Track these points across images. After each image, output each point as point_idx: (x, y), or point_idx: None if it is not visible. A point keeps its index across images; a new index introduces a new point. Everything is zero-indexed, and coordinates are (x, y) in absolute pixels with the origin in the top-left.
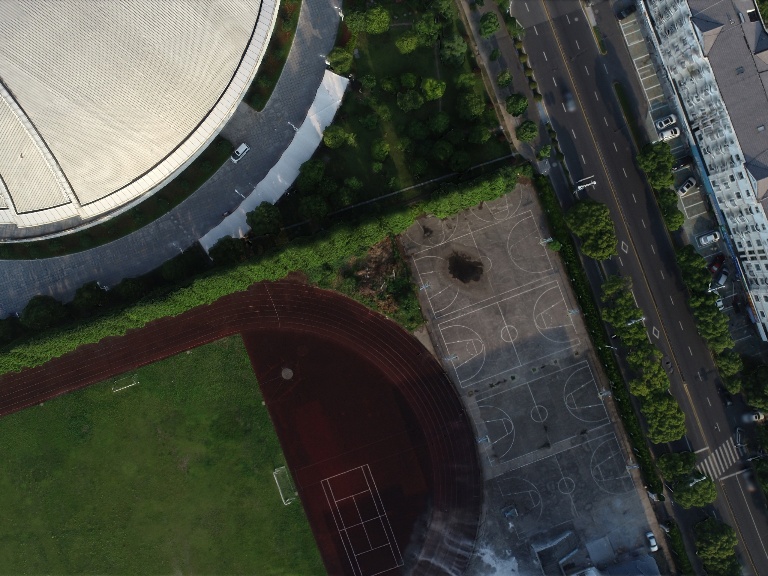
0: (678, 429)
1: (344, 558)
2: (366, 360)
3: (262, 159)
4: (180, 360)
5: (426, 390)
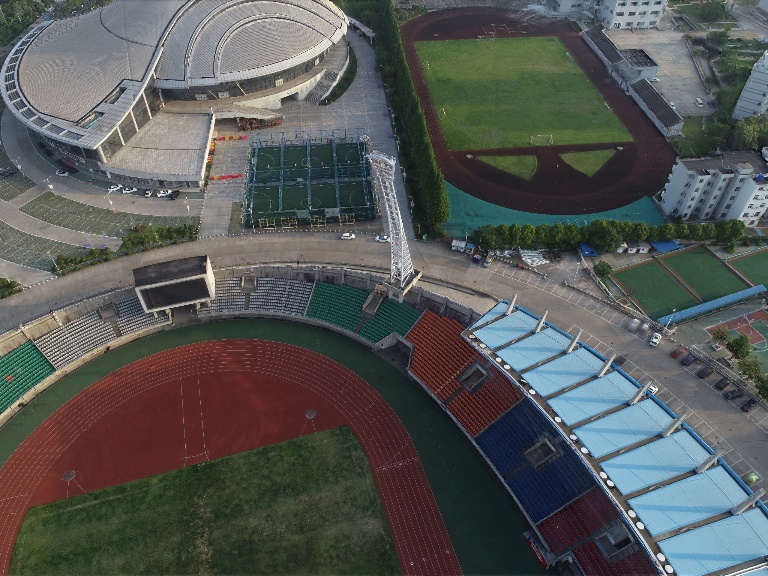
0: None
1: None
2: None
3: None
4: None
5: None
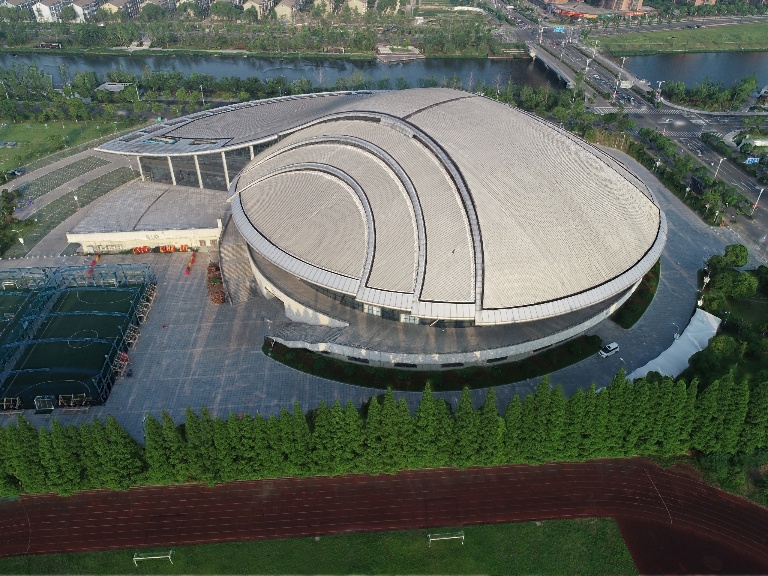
0: None
1: None
2: None
3: None
4: (526, 530)
5: None
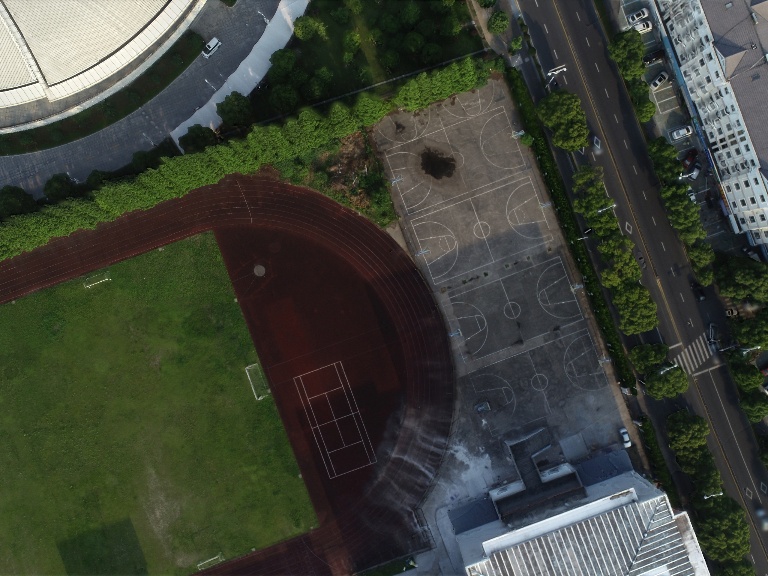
0: (650, 319)
1: (317, 455)
2: (339, 257)
3: (234, 54)
4: (152, 257)
5: (399, 287)
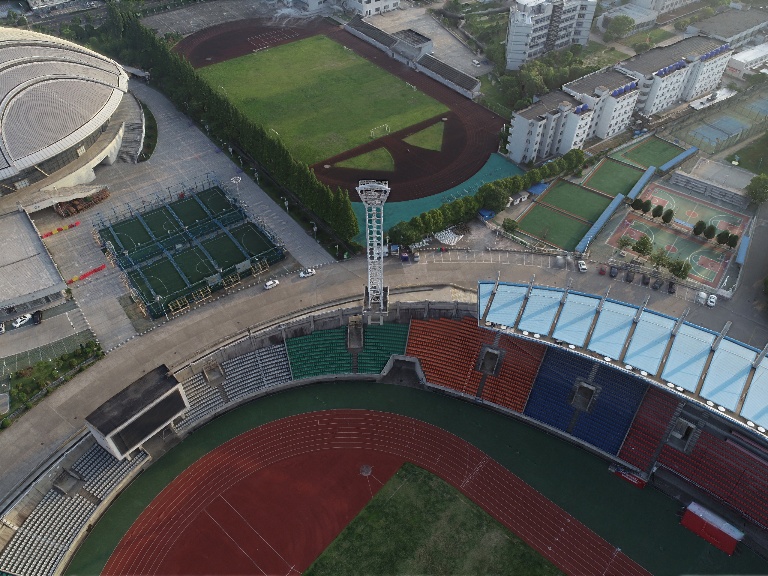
0: None
1: None
2: None
3: None
4: None
5: None
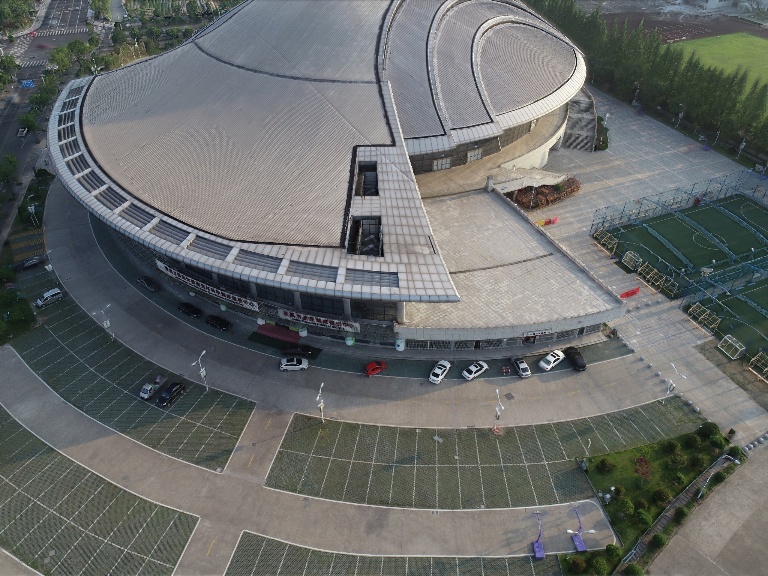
0: None
1: None
2: None
3: None
4: None
5: None
